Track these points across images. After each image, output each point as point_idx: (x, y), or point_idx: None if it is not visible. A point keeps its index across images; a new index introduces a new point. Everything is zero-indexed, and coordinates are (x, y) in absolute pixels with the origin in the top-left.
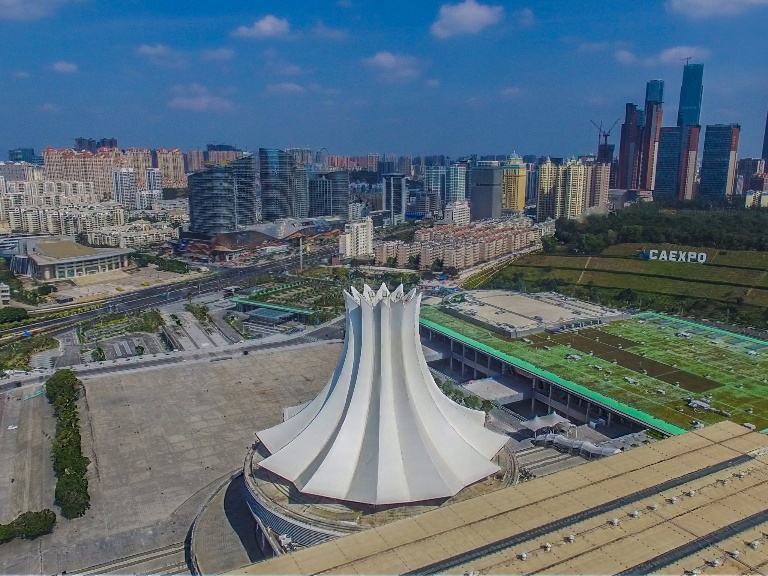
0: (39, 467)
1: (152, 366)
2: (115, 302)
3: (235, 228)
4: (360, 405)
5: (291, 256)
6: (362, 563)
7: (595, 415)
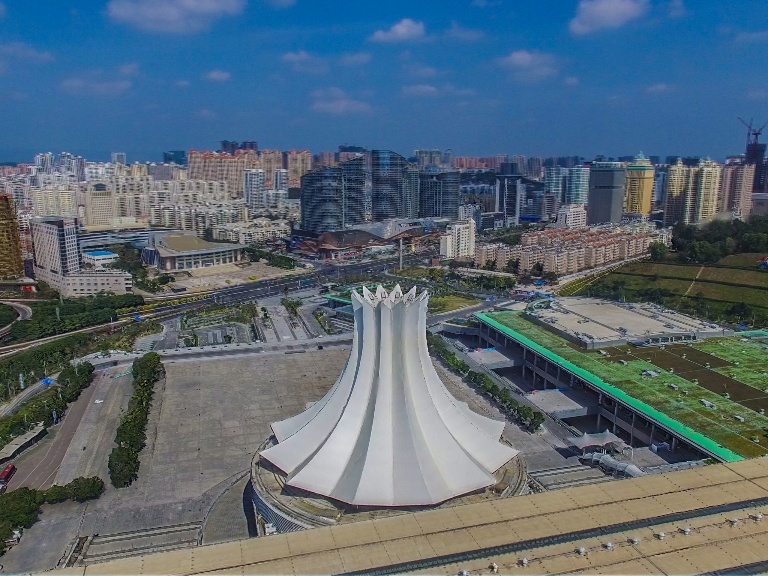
0: (108, 439)
1: (233, 355)
2: (222, 293)
3: (342, 227)
4: (358, 404)
5: (395, 256)
6: (302, 559)
7: (661, 438)
